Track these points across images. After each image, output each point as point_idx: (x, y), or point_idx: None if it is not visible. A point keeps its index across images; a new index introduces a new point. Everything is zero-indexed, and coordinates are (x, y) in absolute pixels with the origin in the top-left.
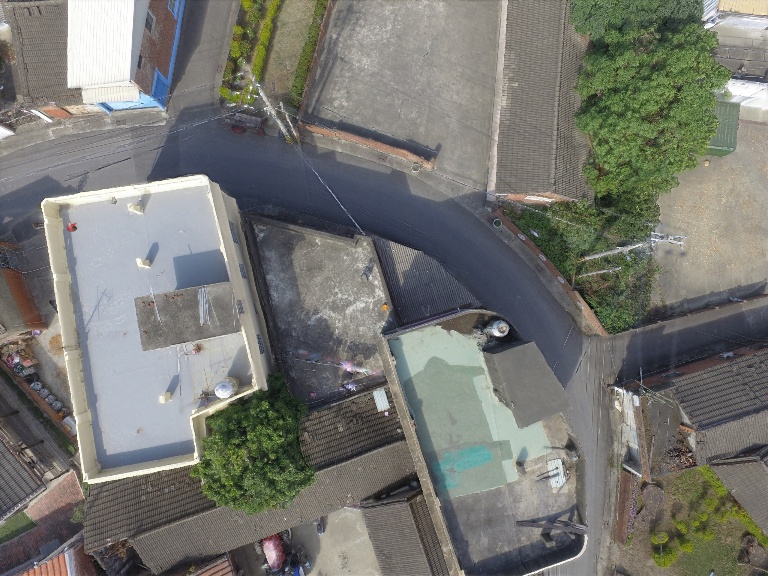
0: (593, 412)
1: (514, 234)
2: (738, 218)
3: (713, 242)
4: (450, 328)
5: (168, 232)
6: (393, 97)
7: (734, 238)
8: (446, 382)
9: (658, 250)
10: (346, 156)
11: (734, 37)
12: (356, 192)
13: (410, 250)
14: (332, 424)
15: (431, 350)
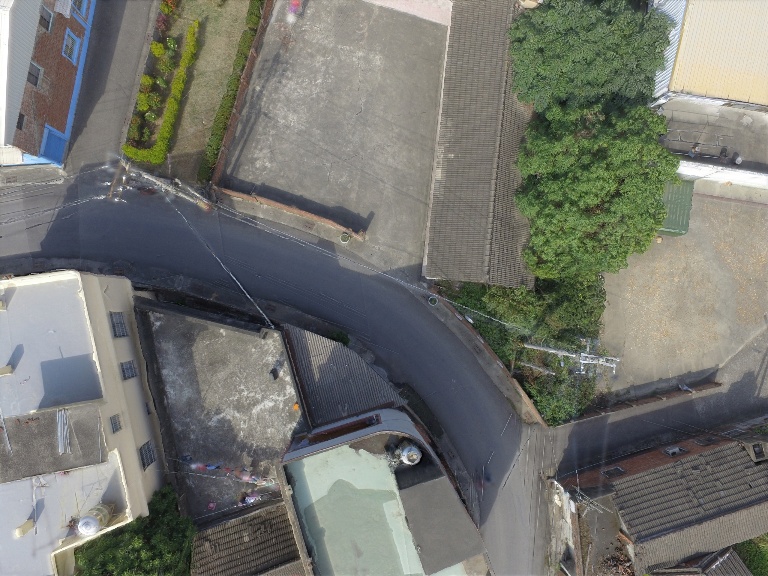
0: (531, 507)
1: (451, 312)
2: (690, 300)
3: (663, 325)
4: (359, 447)
5: (35, 332)
6: (322, 159)
7: (685, 321)
8: (353, 508)
9: (605, 333)
10: (268, 223)
11: (689, 112)
12: (278, 263)
13: (328, 341)
14: (237, 532)
15: (337, 472)
